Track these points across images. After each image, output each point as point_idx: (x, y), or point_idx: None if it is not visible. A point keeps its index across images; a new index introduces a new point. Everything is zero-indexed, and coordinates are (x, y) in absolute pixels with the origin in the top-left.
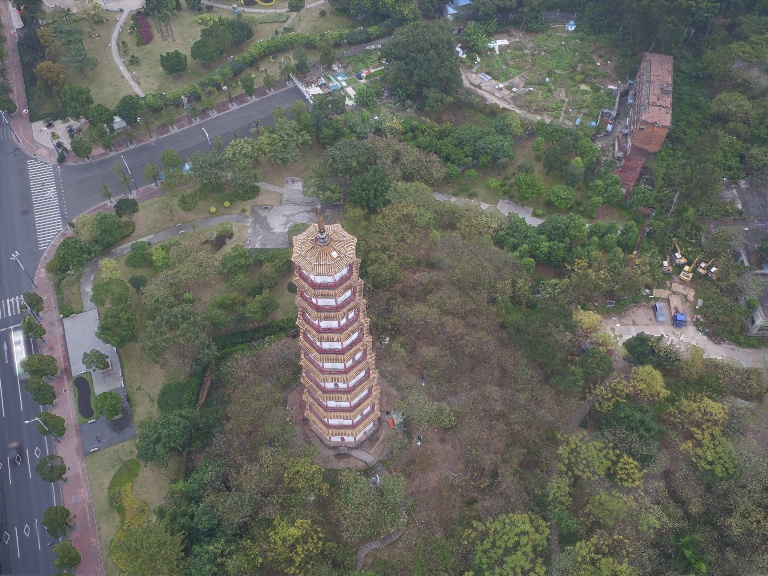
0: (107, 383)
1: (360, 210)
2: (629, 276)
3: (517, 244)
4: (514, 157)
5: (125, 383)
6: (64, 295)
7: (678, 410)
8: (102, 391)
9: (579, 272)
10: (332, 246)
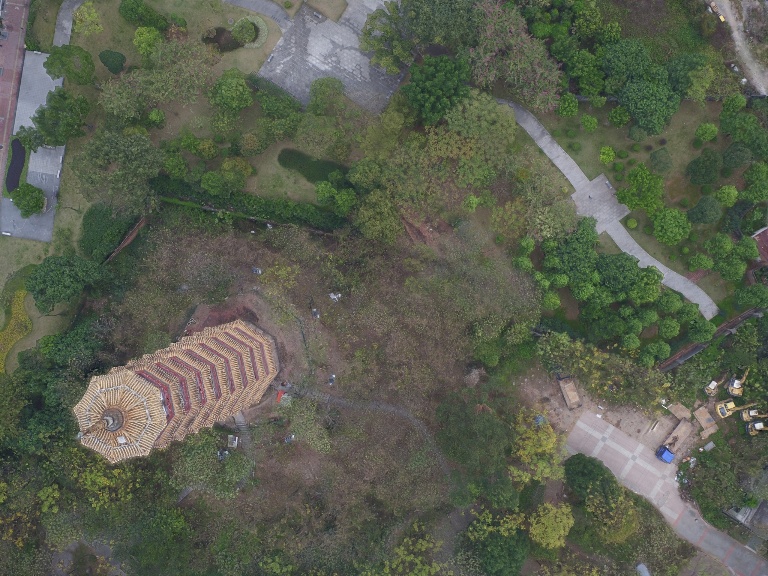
0: (44, 163)
1: (402, 118)
2: (649, 387)
3: (559, 268)
4: (659, 134)
5: (62, 174)
6: (36, 17)
7: (551, 574)
8: (36, 170)
9: (583, 368)
10: (121, 431)
